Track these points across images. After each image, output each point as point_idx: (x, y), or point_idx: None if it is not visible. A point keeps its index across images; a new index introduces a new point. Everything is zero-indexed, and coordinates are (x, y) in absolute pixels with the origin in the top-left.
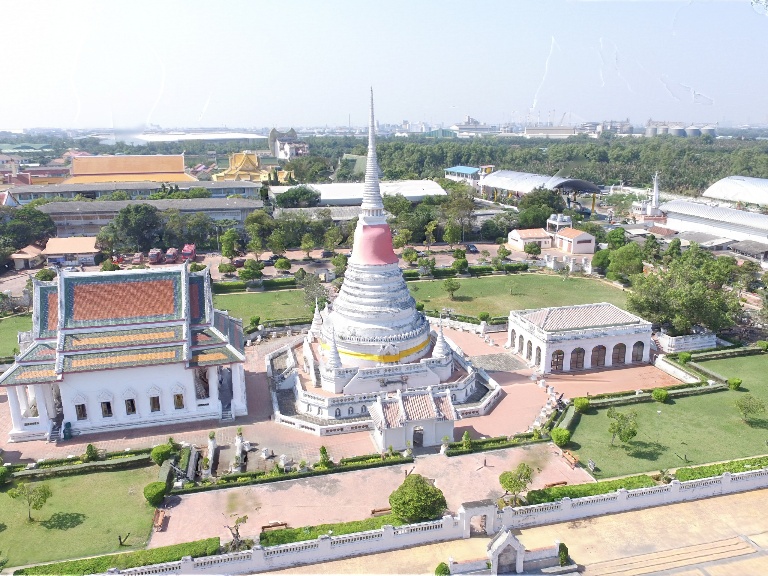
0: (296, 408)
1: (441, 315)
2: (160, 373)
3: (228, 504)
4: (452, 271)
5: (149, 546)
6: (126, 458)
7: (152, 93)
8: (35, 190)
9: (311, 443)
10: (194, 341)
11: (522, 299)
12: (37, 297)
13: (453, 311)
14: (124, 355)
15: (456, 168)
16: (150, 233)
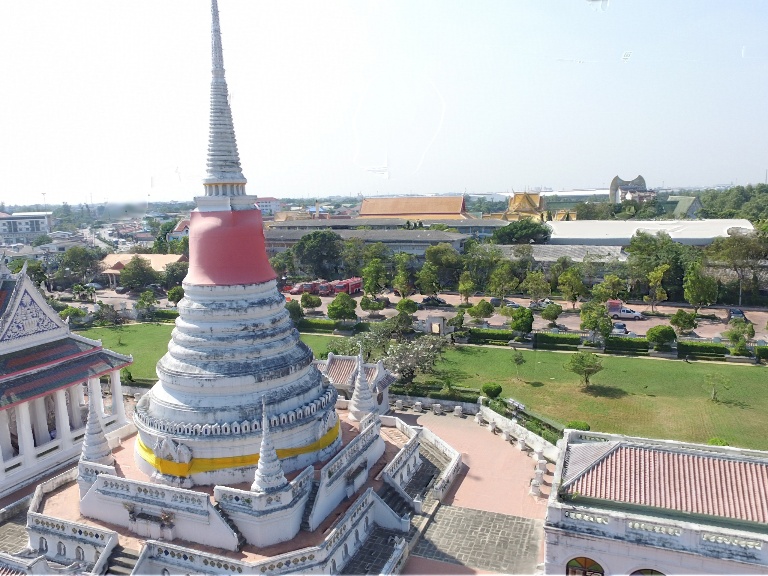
0: None
1: (505, 411)
2: None
3: None
4: (643, 344)
5: None
6: None
7: (429, 131)
8: (300, 224)
9: None
10: None
11: (726, 413)
12: None
13: (521, 408)
14: None
15: None
16: (331, 263)
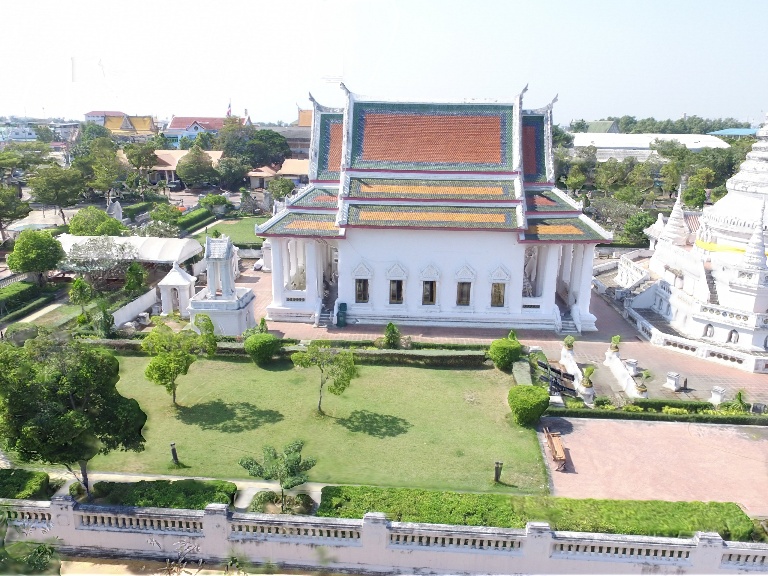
0: (677, 331)
1: None
2: (478, 246)
3: (674, 446)
4: None
5: (556, 494)
6: (447, 351)
7: (383, 41)
8: None
9: (744, 380)
10: (530, 205)
11: None
12: (317, 126)
13: None
14: (431, 212)
15: (725, 131)
16: None
